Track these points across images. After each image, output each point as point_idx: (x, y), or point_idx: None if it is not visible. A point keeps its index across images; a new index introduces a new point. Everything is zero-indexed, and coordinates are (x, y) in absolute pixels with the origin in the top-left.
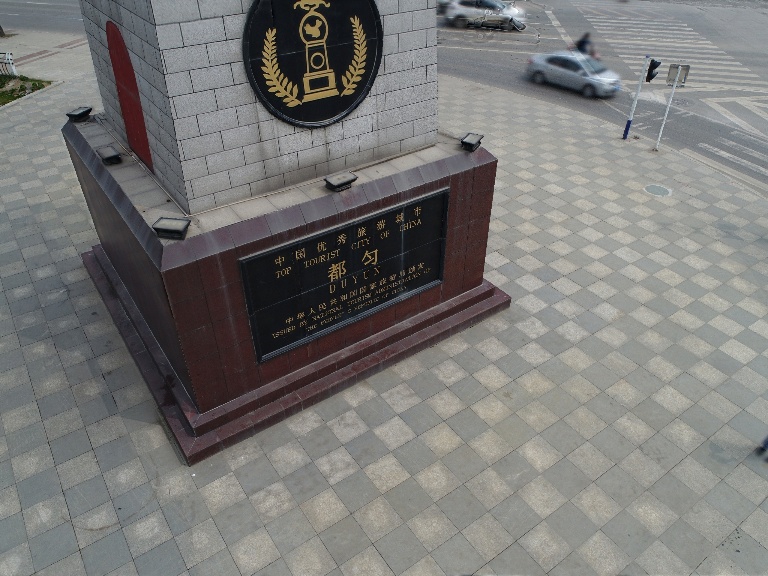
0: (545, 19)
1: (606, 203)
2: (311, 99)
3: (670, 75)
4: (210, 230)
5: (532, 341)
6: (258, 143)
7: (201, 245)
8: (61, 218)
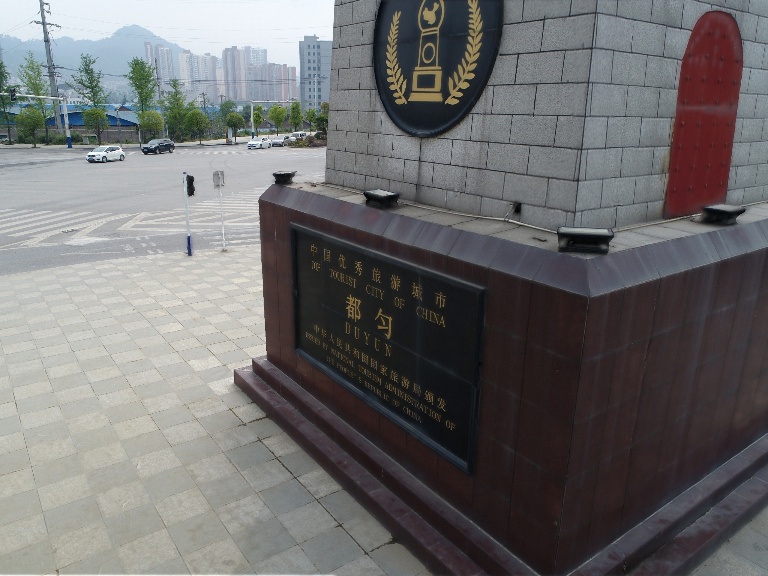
0: None
1: None
2: None
3: (215, 182)
4: None
5: None
6: None
7: None
8: None
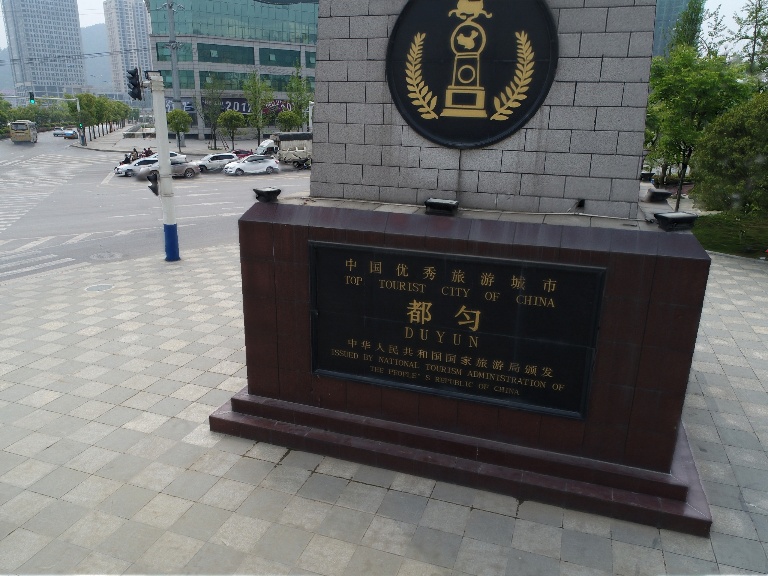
0: None
1: (148, 297)
2: None
3: None
4: None
5: None
6: None
7: None
8: None
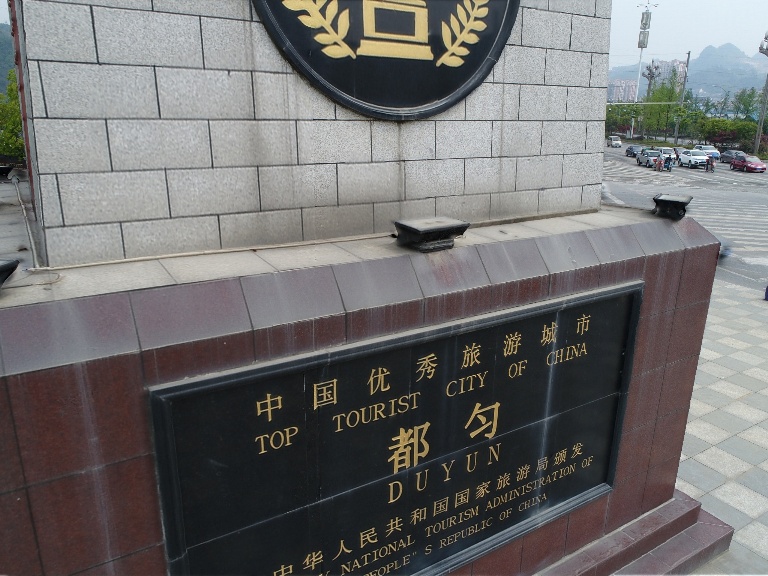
0: (605, 198)
1: None
2: (376, 53)
3: None
4: (73, 296)
5: None
6: (248, 121)
7: (32, 333)
8: None
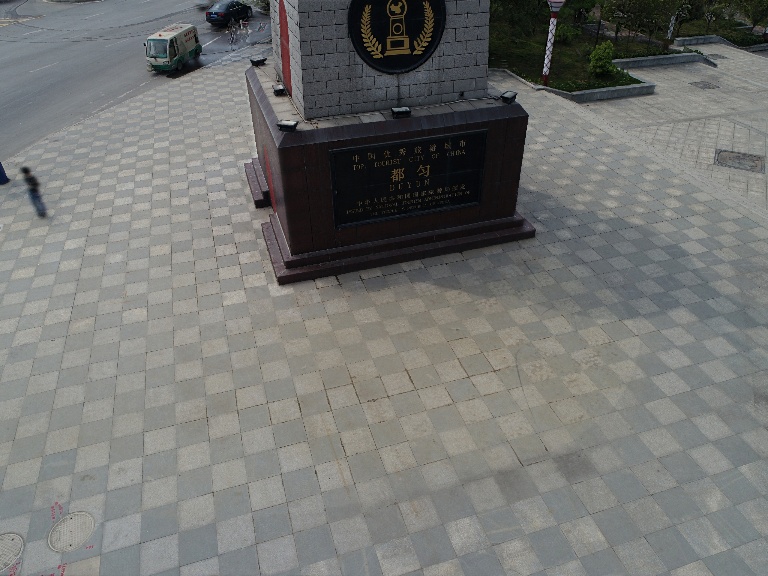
0: None
1: (59, 223)
2: None
3: None
4: None
5: None
6: None
7: None
8: (589, 290)
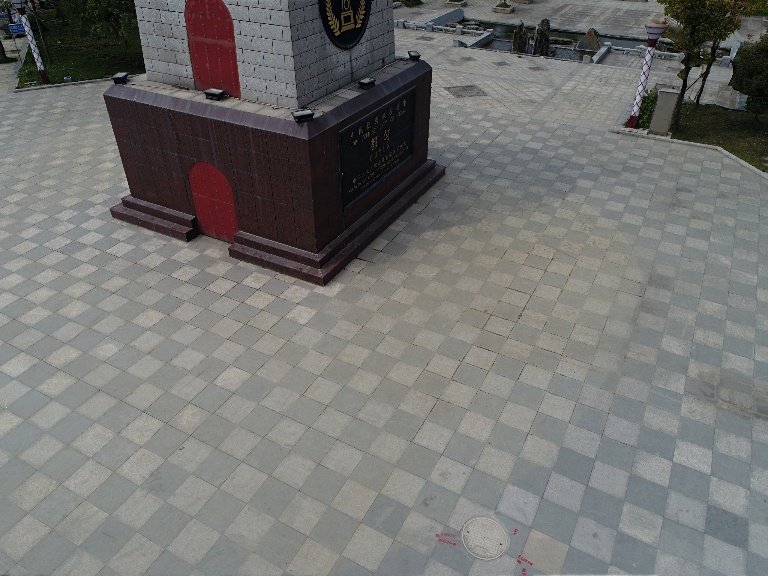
0: None
1: None
2: None
3: None
4: None
5: (99, 203)
6: None
7: None
8: (524, 191)
